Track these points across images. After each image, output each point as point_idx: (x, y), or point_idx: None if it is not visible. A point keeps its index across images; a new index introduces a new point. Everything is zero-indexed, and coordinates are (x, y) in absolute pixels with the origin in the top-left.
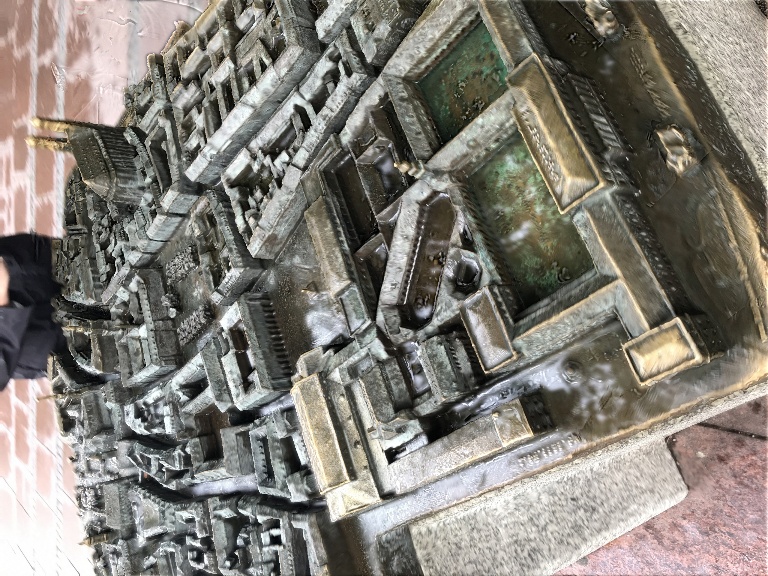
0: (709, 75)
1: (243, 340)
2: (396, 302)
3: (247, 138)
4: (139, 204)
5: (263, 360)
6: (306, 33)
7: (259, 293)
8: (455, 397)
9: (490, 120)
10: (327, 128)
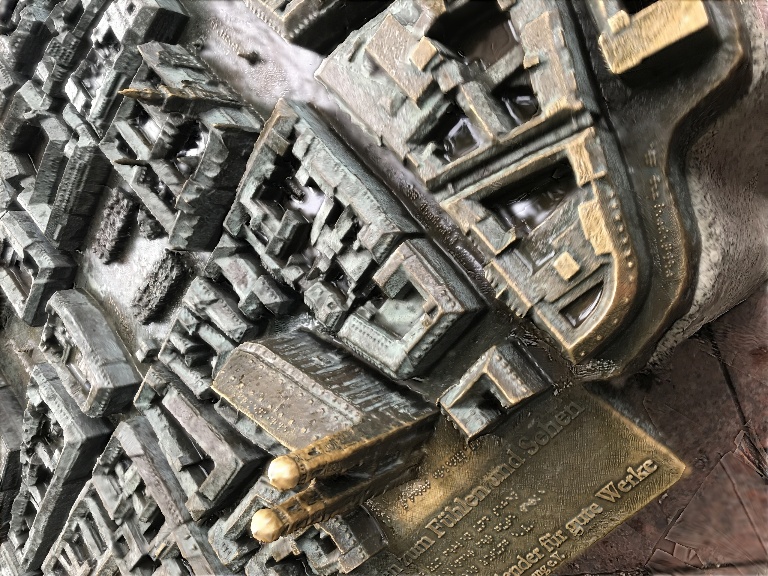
0: None
1: None
2: None
3: None
4: (225, 353)
5: None
6: None
7: None
8: None
9: None
10: None
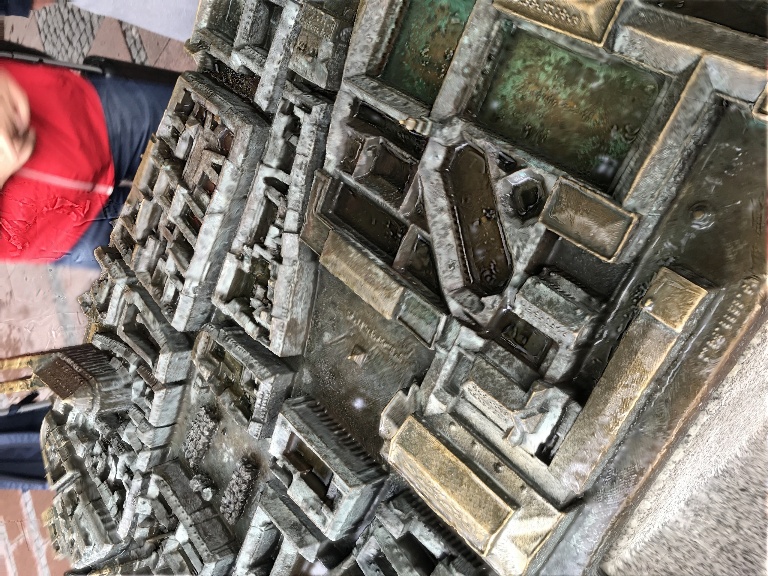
0: None
1: (303, 459)
2: (463, 283)
3: (225, 254)
4: None
5: (337, 458)
6: (249, 115)
7: (300, 397)
8: (585, 332)
9: (475, 34)
10: (307, 177)
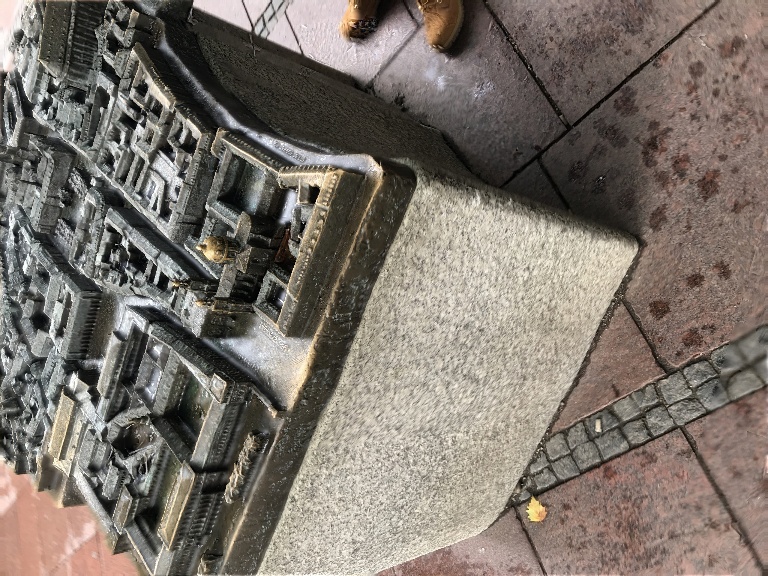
0: (280, 527)
1: None
2: (122, 426)
3: None
4: None
5: (70, 339)
6: (184, 229)
7: (95, 293)
8: None
9: None
10: None
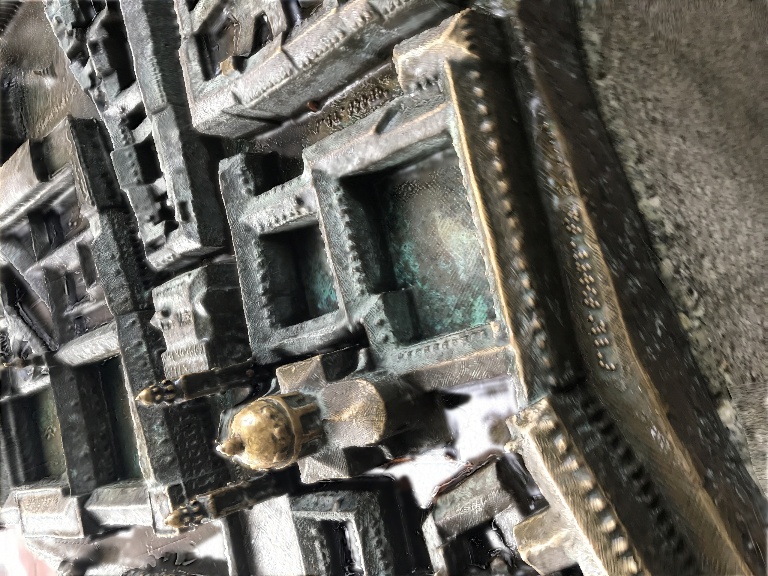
0: None
1: None
2: None
3: None
4: None
5: None
6: (236, 123)
7: None
8: None
9: None
10: None
